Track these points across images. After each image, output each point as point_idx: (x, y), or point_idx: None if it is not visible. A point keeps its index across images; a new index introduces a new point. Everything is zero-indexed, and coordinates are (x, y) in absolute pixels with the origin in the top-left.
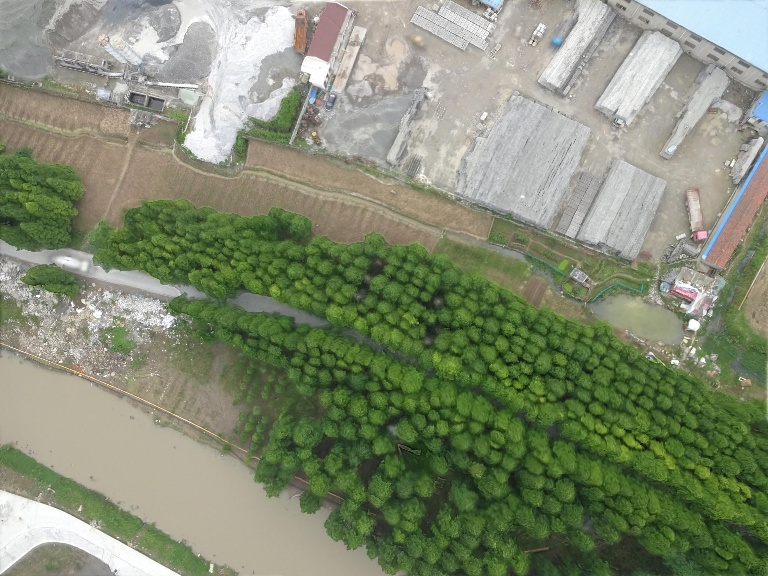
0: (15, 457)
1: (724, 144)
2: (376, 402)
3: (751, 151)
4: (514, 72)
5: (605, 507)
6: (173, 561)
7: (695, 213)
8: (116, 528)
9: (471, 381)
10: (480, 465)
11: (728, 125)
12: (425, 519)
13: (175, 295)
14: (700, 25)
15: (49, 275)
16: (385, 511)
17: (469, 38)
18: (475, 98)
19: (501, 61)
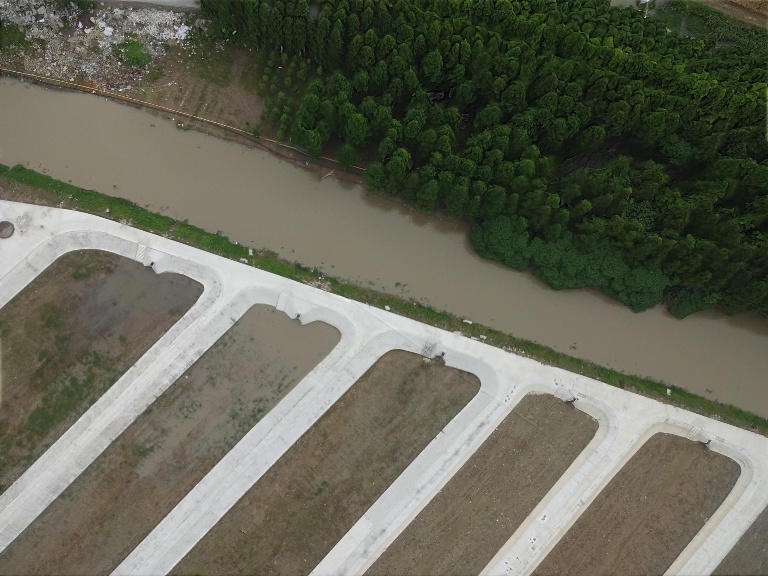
0: (28, 175)
1: None
2: (404, 35)
3: None
4: None
5: (609, 102)
6: (212, 246)
7: None
8: (148, 224)
9: (483, 13)
10: (501, 79)
11: None
12: (456, 151)
13: (188, 5)
14: None
15: None
16: (423, 133)
17: None
18: None
19: None
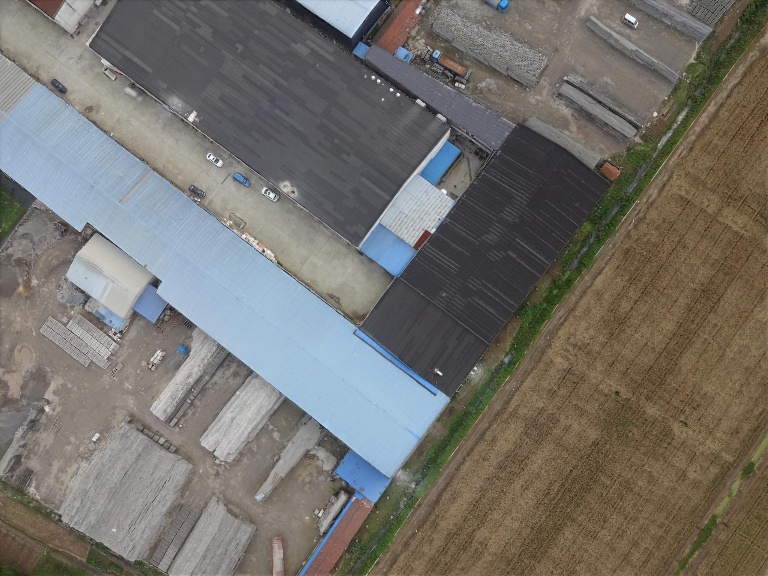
0: None
1: (316, 492)
2: None
3: (332, 508)
4: (131, 394)
5: None
6: None
7: (278, 562)
8: None
9: None
10: None
11: (322, 473)
12: None
13: None
14: (286, 386)
15: None
16: None
17: (91, 356)
18: (91, 416)
19: (120, 381)
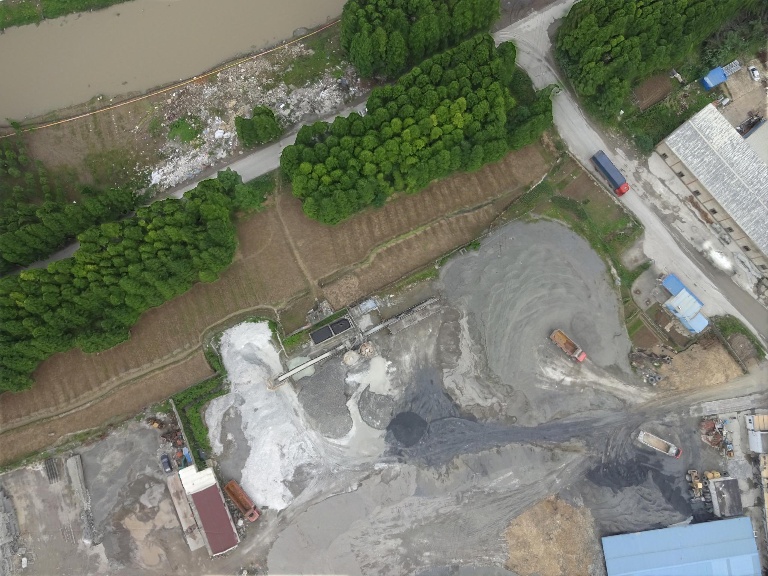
0: None
1: None
2: None
3: None
4: None
5: None
6: None
7: None
8: None
9: None
10: None
11: None
12: None
13: None
14: None
15: (252, 129)
16: None
17: None
18: (47, 571)
19: None
